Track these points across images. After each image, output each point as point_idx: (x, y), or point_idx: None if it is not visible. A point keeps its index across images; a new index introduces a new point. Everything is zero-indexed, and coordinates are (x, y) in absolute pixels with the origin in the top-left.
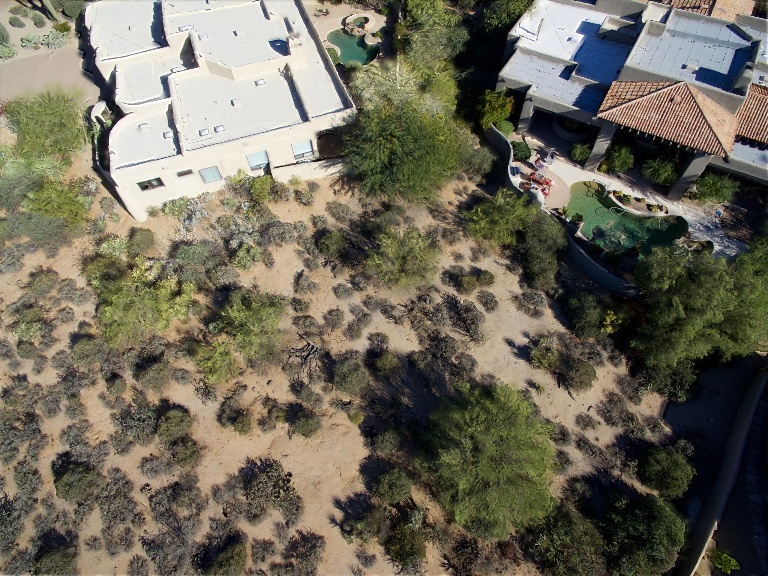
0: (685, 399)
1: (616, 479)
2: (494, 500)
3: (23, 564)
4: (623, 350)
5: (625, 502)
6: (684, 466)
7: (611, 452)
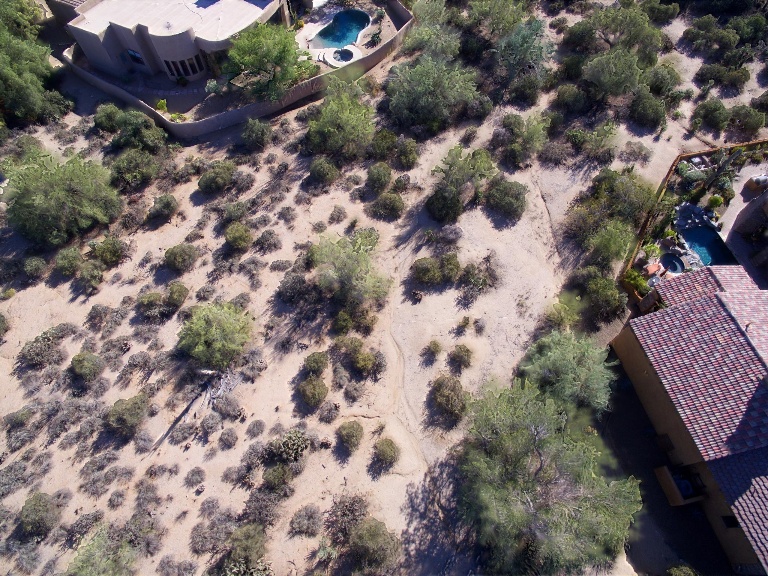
0: (72, 102)
1: (110, 144)
2: (84, 187)
3: (27, 552)
4: (26, 125)
5: (117, 135)
6: (106, 107)
7: (92, 142)
